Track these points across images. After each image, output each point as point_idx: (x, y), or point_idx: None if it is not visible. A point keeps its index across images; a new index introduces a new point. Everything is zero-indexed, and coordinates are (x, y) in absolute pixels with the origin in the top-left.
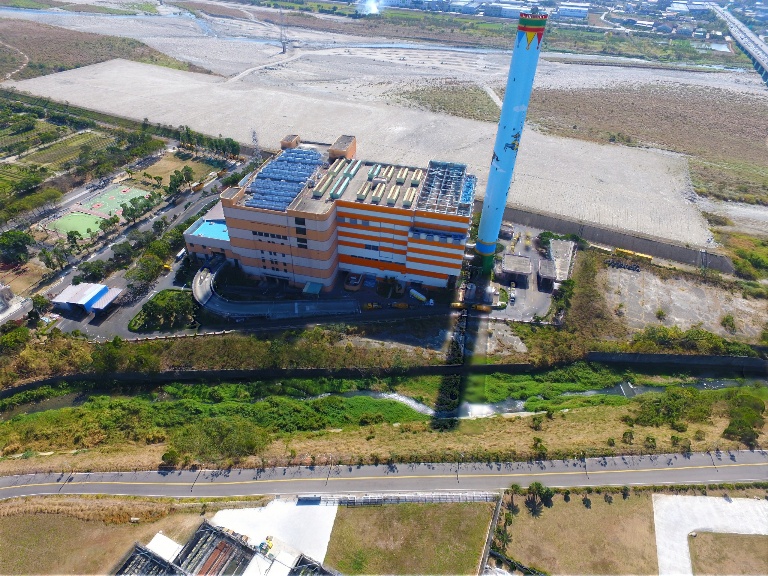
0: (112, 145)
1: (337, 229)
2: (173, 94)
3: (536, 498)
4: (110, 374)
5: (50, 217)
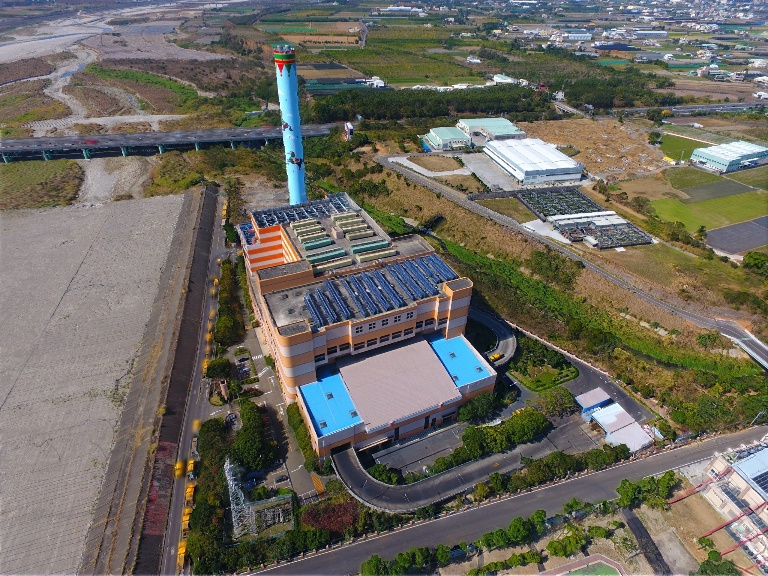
0: None
1: None
2: None
3: None
4: None
5: None
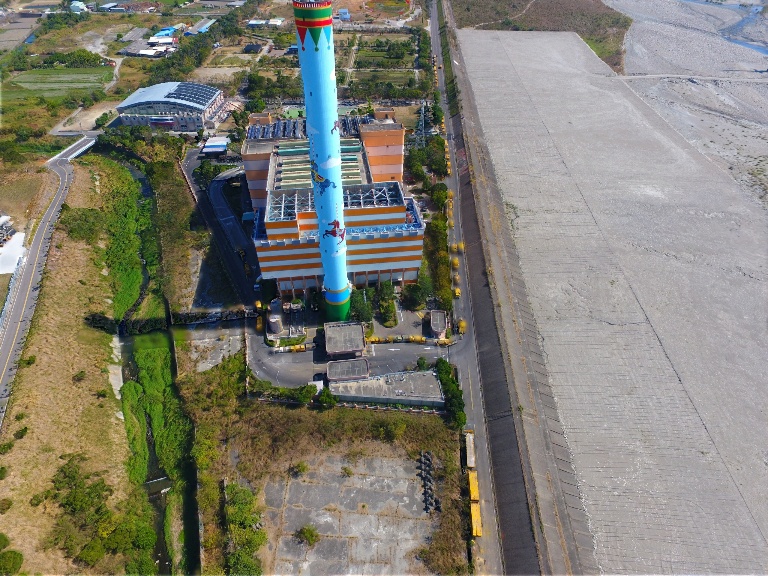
0: None
1: None
2: (536, 70)
3: None
4: None
5: (298, 106)
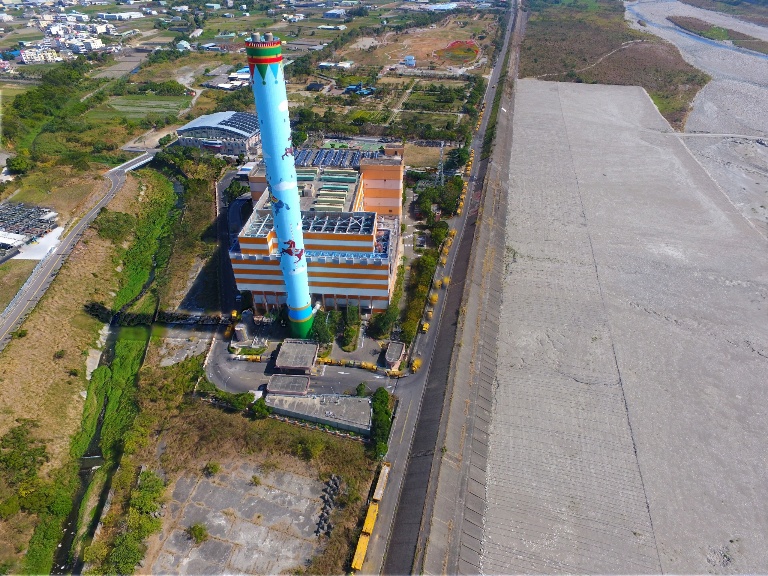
0: None
1: None
2: (586, 121)
3: None
4: None
5: (338, 140)
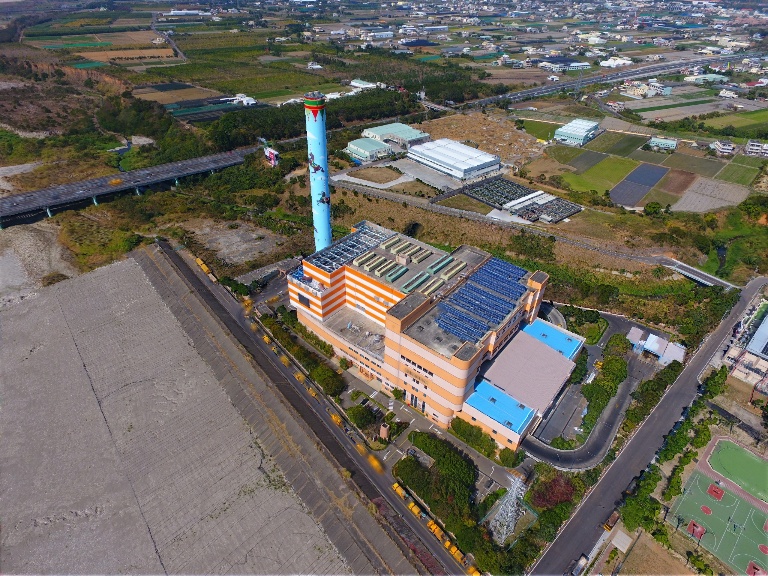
0: None
1: None
2: None
3: None
4: None
5: None
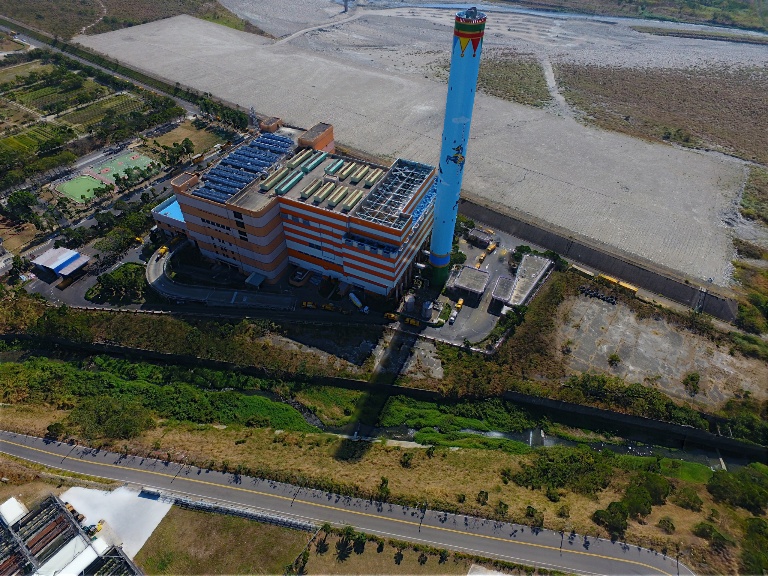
0: (139, 109)
1: (283, 224)
2: (218, 56)
3: (349, 541)
4: (53, 338)
5: (62, 178)
